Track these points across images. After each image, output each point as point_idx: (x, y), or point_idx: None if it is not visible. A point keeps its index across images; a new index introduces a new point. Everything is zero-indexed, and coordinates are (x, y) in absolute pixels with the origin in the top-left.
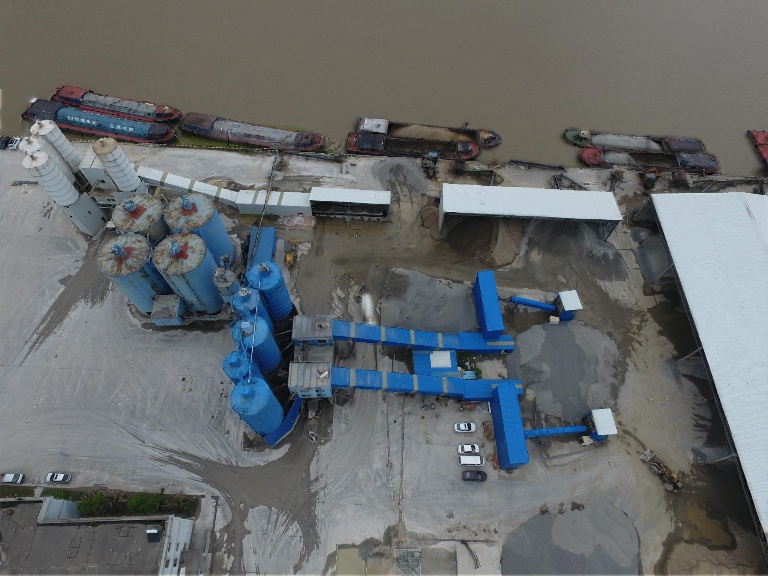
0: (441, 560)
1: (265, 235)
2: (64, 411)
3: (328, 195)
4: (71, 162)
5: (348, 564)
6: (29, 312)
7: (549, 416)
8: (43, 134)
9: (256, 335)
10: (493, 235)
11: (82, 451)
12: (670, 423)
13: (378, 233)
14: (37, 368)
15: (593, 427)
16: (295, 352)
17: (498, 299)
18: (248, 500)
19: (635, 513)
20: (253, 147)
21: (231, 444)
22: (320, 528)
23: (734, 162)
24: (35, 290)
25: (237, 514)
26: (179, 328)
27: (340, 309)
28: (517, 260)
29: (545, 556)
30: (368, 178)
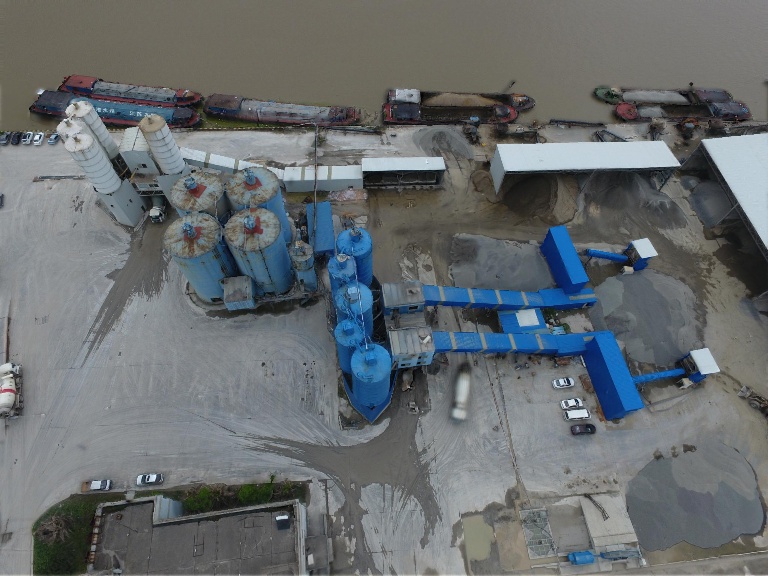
0: (568, 516)
1: (322, 210)
2: (141, 409)
3: (380, 165)
4: (108, 147)
5: (475, 532)
6: (80, 311)
7: (642, 364)
8: (81, 116)
9: (362, 301)
10: (552, 193)
11: (169, 449)
12: (759, 359)
13: (433, 201)
14: (101, 368)
15: (690, 369)
16: (386, 322)
17: (576, 252)
18: (358, 479)
19: (745, 448)
20: (285, 126)
21: (328, 425)
22: (439, 499)
23: (761, 108)
24: (82, 288)
25: (350, 495)
26: (247, 313)
27: (411, 279)
28: (577, 216)
29: (672, 499)
30: (411, 148)
